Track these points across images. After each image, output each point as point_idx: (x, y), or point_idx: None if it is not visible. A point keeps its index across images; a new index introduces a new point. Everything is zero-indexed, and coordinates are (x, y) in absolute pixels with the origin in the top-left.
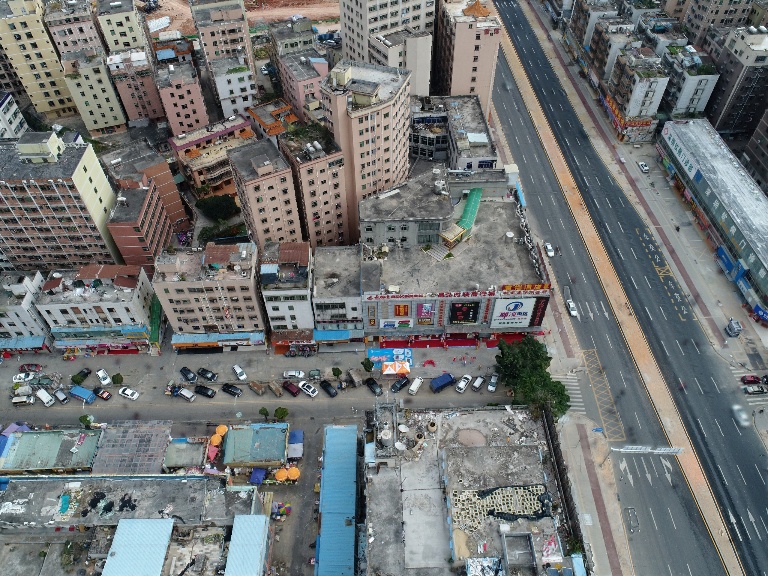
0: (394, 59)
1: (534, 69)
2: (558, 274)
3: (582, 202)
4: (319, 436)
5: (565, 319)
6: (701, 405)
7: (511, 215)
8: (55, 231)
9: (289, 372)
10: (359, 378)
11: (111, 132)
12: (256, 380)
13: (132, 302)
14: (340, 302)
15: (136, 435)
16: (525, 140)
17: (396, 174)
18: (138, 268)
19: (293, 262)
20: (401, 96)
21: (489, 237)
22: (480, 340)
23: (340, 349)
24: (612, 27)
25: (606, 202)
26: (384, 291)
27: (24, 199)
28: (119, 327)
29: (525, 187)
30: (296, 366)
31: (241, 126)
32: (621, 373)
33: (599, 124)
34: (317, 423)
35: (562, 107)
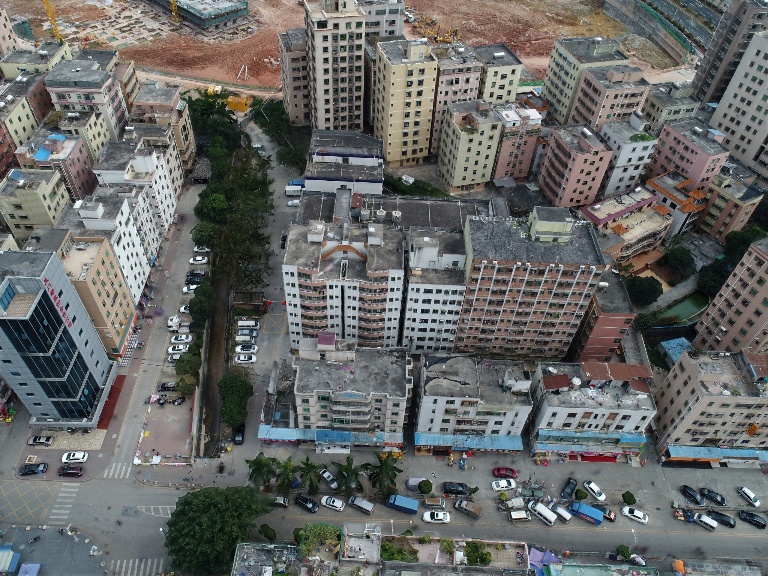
0: None
1: None
2: None
3: None
4: None
5: None
6: None
7: None
8: (533, 316)
9: None
10: None
11: (470, 189)
12: None
13: None
14: None
15: None
16: None
17: None
18: (646, 369)
19: None
20: None
21: None
22: None
23: None
24: None
25: None
26: None
27: (532, 282)
28: (616, 434)
29: None
30: None
31: (652, 200)
32: None
33: None
34: None
35: None
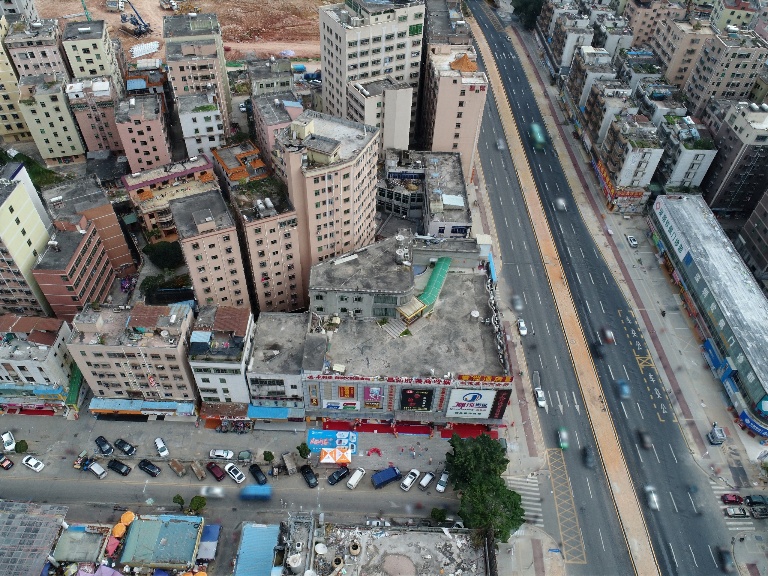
0: (371, 110)
1: (526, 126)
2: (529, 356)
3: (563, 275)
4: (238, 532)
5: (531, 410)
6: (674, 526)
7: (480, 290)
8: None
9: (216, 451)
10: (293, 465)
11: (68, 162)
12: (179, 457)
13: (46, 362)
14: (278, 379)
15: (23, 522)
16: (509, 201)
17: (358, 236)
18: (59, 322)
19: (228, 331)
20: (366, 155)
21: (453, 314)
22: (434, 428)
23: (278, 427)
24: (608, 90)
25: (589, 277)
26: (328, 370)
27: None
28: (32, 386)
29: (504, 254)
30: (226, 444)
31: (202, 168)
32: (588, 480)
33: (589, 190)
34: (239, 516)
35: (552, 168)
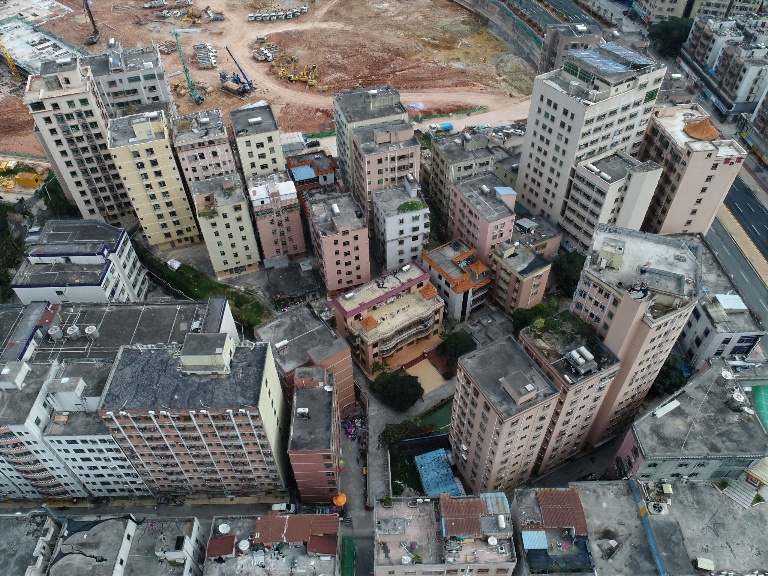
0: (612, 195)
1: None
2: None
3: None
4: None
5: None
6: None
7: None
8: (215, 456)
9: None
10: None
11: (241, 271)
12: None
13: None
14: None
15: None
16: (740, 277)
17: None
18: (336, 520)
19: (565, 527)
20: None
21: None
22: None
23: None
24: None
25: None
26: None
27: (185, 427)
28: None
29: (765, 349)
30: None
31: (420, 280)
32: None
33: None
34: None
35: None
